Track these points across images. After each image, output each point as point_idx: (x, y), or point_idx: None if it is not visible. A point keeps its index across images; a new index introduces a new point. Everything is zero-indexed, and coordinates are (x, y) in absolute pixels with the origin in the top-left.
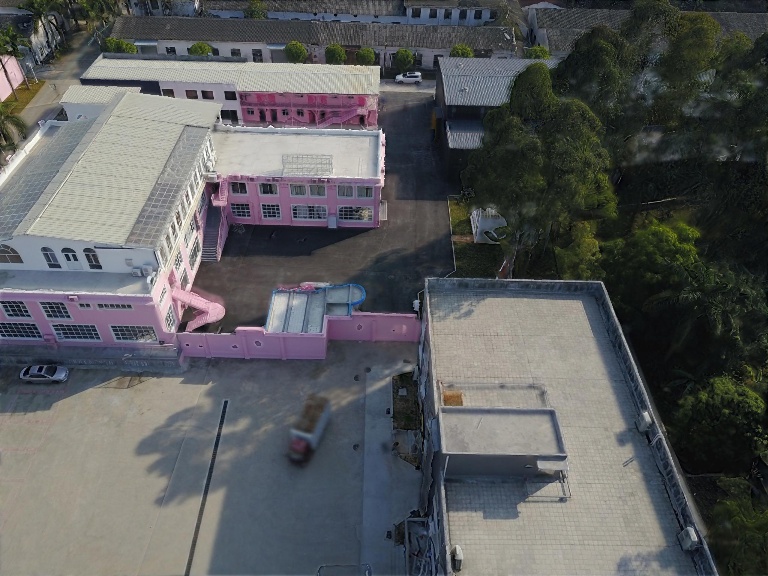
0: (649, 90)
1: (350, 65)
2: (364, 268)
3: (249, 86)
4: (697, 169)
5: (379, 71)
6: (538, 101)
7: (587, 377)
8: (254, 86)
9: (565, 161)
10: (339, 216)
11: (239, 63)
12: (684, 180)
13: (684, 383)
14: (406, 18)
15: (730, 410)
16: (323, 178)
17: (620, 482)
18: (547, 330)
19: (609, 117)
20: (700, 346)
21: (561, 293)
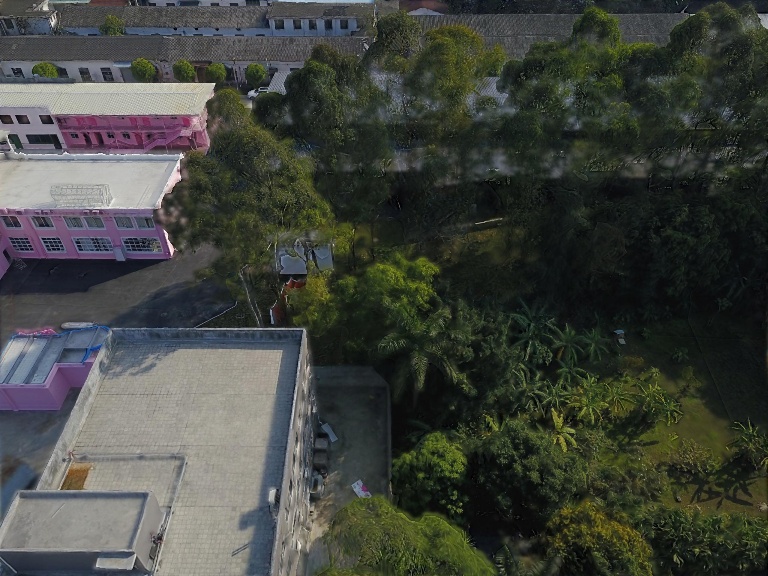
0: (414, 109)
1: (183, 83)
2: (138, 305)
3: (65, 109)
4: (458, 195)
5: (211, 89)
6: (227, 131)
7: (244, 444)
8: (70, 109)
9: (242, 199)
10: (126, 248)
11: (66, 84)
12: (438, 208)
13: (420, 435)
14: (270, 30)
15: (428, 473)
16: (95, 210)
17: (218, 575)
18: (226, 387)
19: (336, 144)
20: (439, 394)
21: (264, 341)
